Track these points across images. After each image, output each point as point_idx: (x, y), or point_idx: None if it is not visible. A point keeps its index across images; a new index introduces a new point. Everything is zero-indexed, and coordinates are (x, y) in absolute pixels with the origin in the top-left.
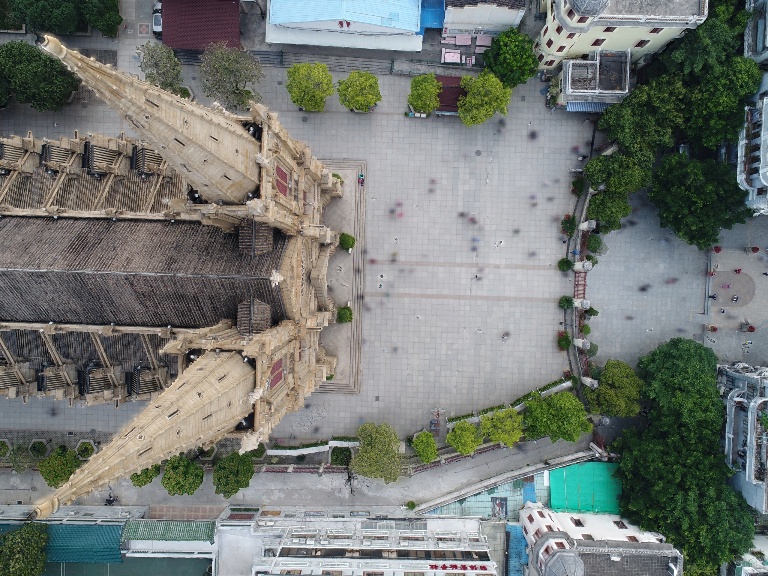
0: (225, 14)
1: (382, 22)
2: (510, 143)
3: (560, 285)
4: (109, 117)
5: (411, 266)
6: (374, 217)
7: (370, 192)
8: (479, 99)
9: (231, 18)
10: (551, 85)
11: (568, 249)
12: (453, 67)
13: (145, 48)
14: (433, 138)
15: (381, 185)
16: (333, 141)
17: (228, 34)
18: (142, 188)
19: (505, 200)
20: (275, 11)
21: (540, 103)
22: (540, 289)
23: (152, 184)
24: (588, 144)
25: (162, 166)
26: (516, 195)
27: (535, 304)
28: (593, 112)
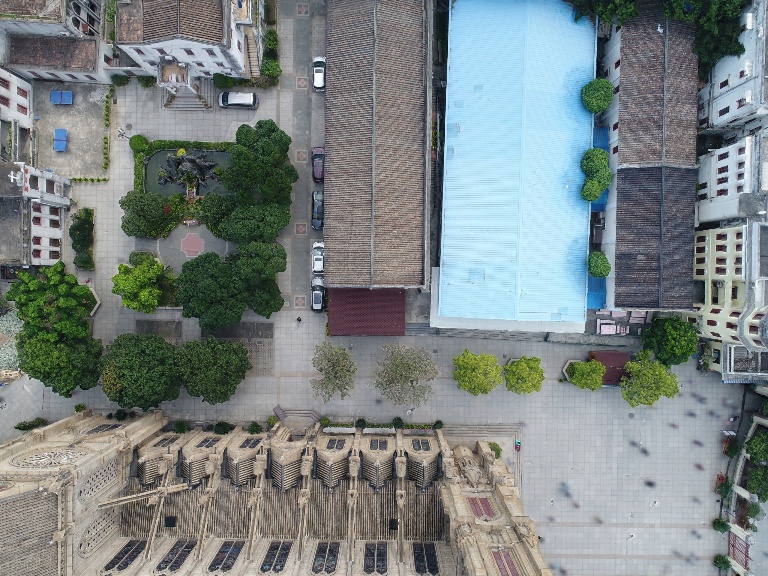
0: (391, 303)
1: (552, 318)
2: (662, 405)
3: (714, 543)
4: (266, 388)
5: (567, 527)
6: (530, 480)
7: (526, 456)
8: (649, 392)
9: (397, 306)
10: (705, 355)
11: (721, 508)
12: (607, 335)
13: (322, 352)
14: (587, 402)
15: (536, 449)
16: (488, 407)
17: (393, 321)
18: (328, 500)
19: (659, 461)
20: (444, 305)
21: (691, 366)
22: (695, 547)
23: (337, 495)
24: (739, 405)
25: (352, 485)
26: (669, 456)
27: (690, 562)
28: (749, 383)
